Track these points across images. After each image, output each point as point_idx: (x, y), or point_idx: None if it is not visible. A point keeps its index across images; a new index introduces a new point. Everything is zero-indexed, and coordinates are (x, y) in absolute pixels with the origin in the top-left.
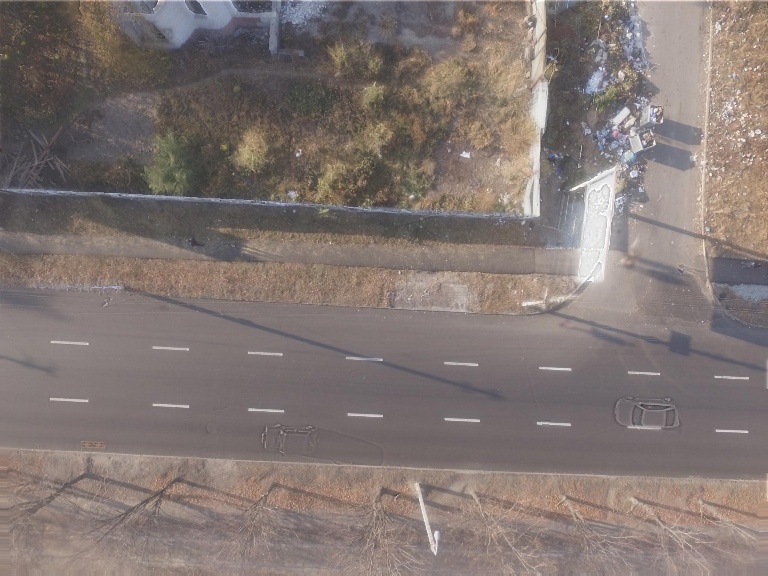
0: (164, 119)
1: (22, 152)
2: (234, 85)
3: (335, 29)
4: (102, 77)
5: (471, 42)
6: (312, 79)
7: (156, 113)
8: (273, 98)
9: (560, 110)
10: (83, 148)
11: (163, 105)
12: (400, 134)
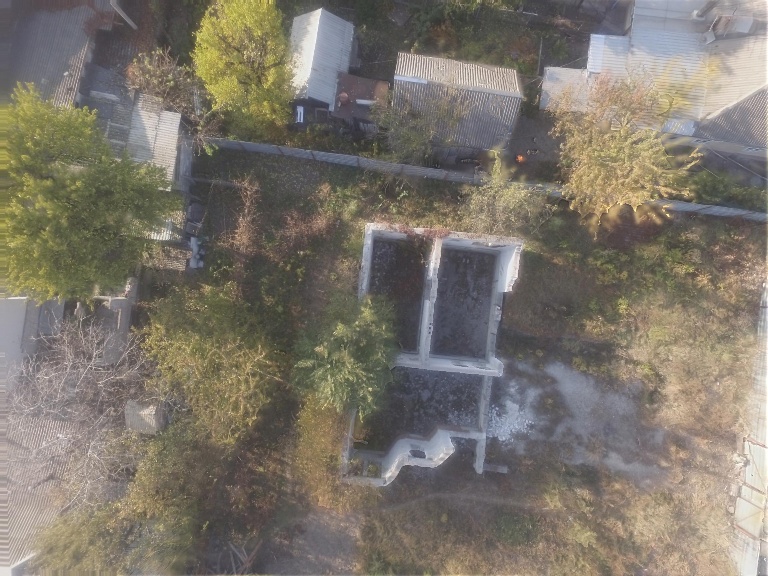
0: (369, 544)
1: (220, 564)
2: (441, 513)
3: (542, 448)
4: (306, 492)
5: (678, 473)
6: (520, 510)
7: (359, 533)
8: (478, 525)
9: (761, 551)
10: (283, 563)
11: (367, 527)
12: (600, 564)
